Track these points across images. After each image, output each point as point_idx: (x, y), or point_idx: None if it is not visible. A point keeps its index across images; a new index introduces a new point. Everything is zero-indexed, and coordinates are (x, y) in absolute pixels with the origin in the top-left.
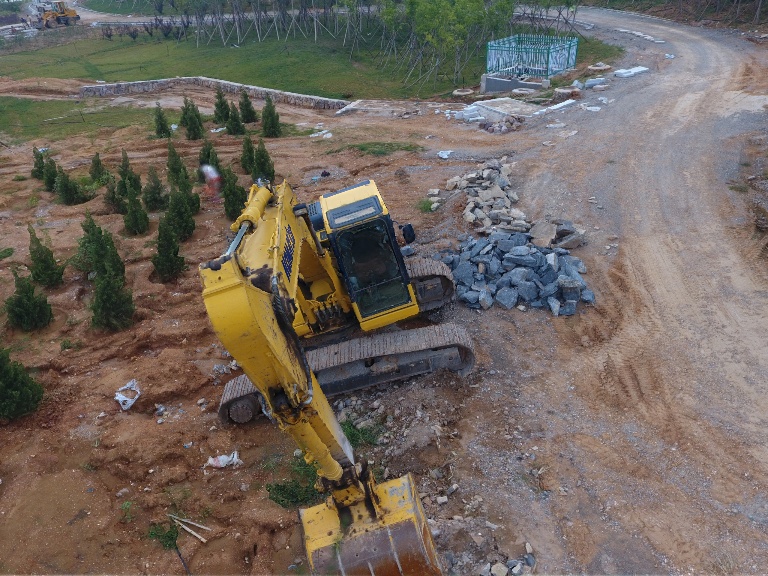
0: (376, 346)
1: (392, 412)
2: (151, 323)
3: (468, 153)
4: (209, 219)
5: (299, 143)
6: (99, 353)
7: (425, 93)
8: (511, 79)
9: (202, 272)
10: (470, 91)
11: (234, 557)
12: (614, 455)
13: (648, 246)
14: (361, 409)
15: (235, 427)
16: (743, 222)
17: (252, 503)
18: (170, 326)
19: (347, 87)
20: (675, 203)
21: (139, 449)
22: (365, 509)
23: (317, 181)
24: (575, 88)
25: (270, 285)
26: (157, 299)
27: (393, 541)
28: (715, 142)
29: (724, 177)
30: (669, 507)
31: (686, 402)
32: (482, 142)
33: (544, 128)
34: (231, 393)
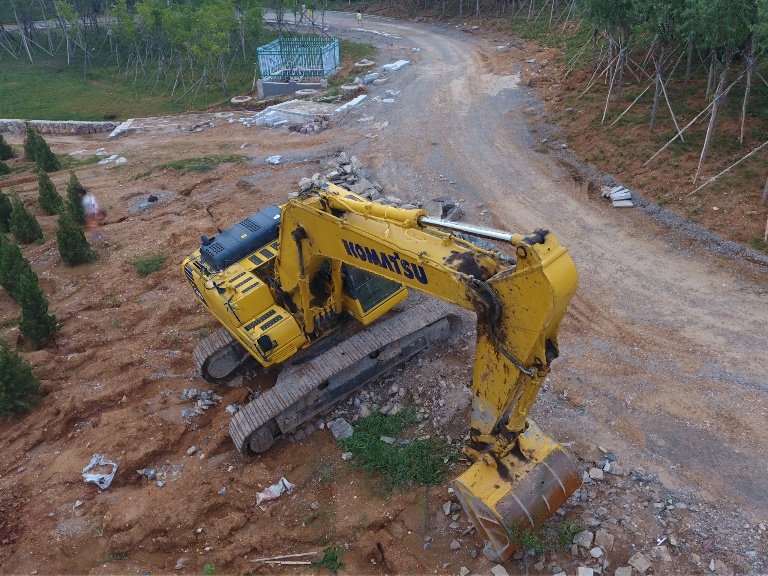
0: (380, 336)
1: (416, 390)
2: (64, 393)
3: (298, 155)
4: (41, 271)
5: (91, 173)
6: (20, 443)
7: (199, 105)
8: (289, 82)
9: (535, 247)
10: (248, 98)
11: (358, 565)
12: (604, 365)
13: (509, 207)
14: (379, 399)
15: (260, 458)
16: (562, 175)
17: (338, 514)
18: (92, 390)
19: (104, 107)
20: (505, 169)
21: (170, 515)
22: (513, 457)
23: (147, 208)
24: (359, 84)
25: (478, 266)
26: (50, 367)
27: (553, 470)
28: (502, 117)
29: (526, 143)
30: (664, 388)
31: (619, 314)
32: (301, 143)
33: (356, 123)
34: (250, 424)
